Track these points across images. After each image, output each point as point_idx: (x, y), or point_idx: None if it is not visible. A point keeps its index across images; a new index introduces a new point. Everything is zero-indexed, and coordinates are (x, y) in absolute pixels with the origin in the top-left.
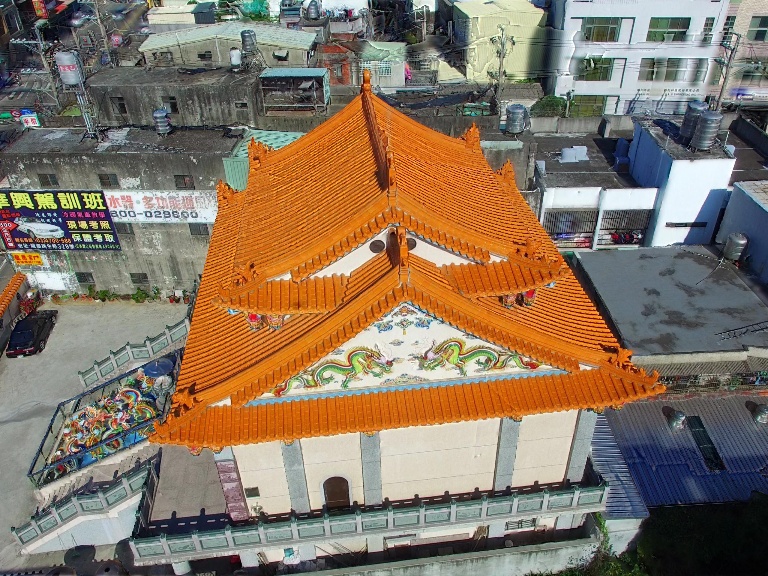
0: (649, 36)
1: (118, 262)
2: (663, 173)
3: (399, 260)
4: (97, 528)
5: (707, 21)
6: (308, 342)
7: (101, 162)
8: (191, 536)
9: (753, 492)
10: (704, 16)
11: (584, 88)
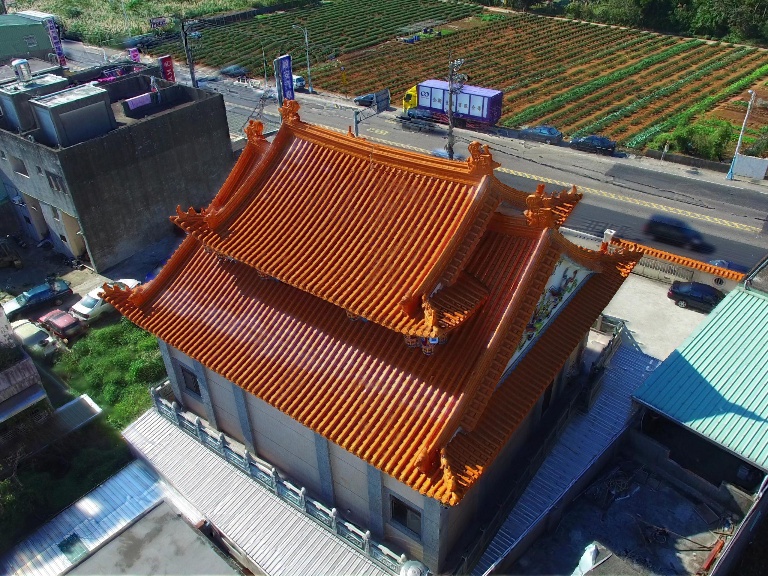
0: None
1: None
2: None
3: None
4: None
5: None
6: None
7: None
8: None
9: (33, 498)
10: None
11: None
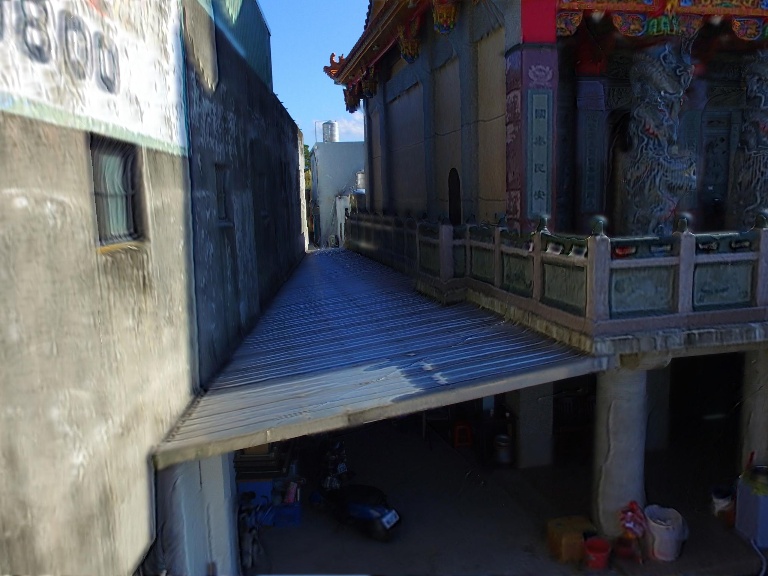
0: None
1: None
2: None
3: None
4: None
5: None
6: None
7: None
8: None
9: None
10: None
11: None
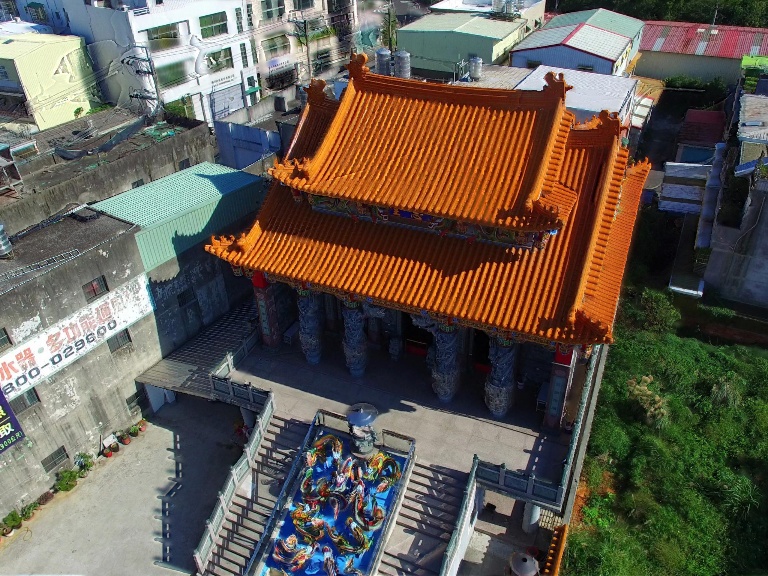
0: (202, 34)
1: (22, 458)
2: None
3: (618, 131)
4: (451, 575)
5: (237, 11)
6: (599, 220)
7: None
8: (573, 447)
9: None
10: (234, 8)
11: (172, 94)
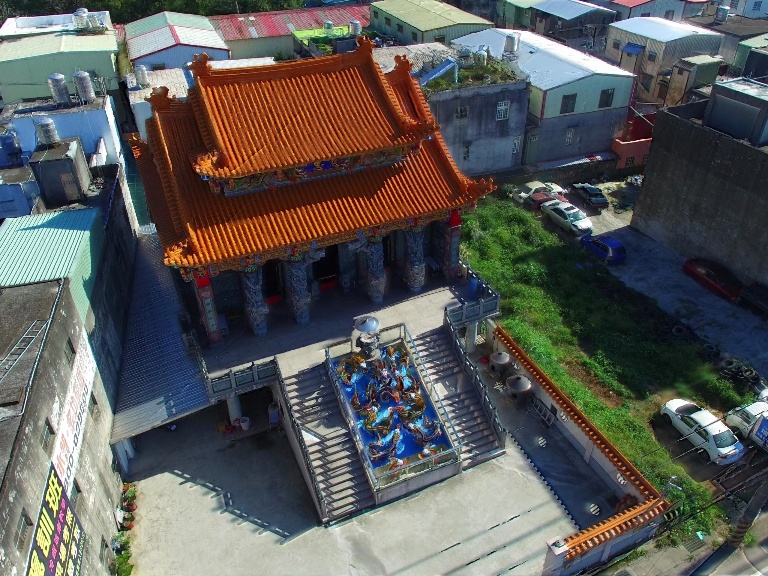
0: None
1: (91, 560)
2: (97, 126)
3: None
4: None
5: None
6: None
7: (36, 416)
8: None
9: None
10: None
11: None
